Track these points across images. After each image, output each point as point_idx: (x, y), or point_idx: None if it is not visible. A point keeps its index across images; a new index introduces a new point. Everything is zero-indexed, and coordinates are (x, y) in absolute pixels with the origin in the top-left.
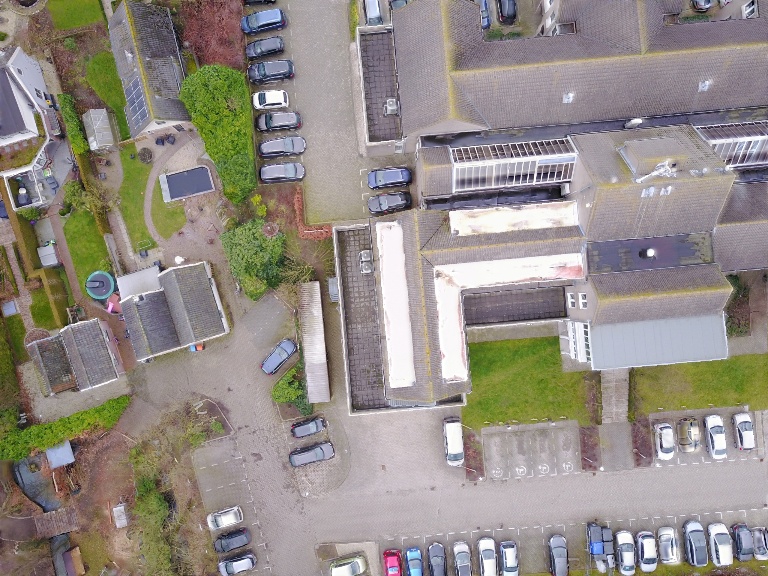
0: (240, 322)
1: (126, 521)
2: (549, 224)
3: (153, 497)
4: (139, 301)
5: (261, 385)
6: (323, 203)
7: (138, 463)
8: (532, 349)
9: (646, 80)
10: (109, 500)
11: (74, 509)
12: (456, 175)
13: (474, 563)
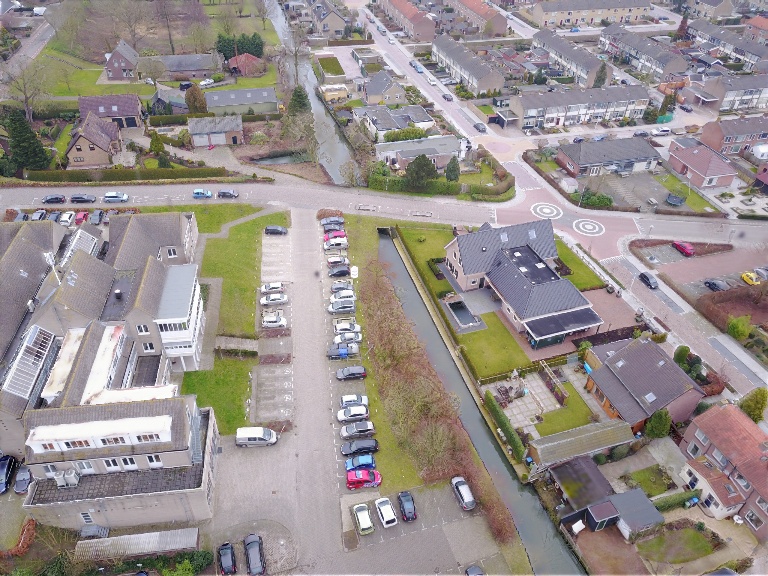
0: None
1: None
2: (78, 342)
3: None
4: None
5: None
6: (1, 536)
7: None
8: (190, 387)
9: (2, 294)
10: None
11: None
12: (13, 392)
13: None
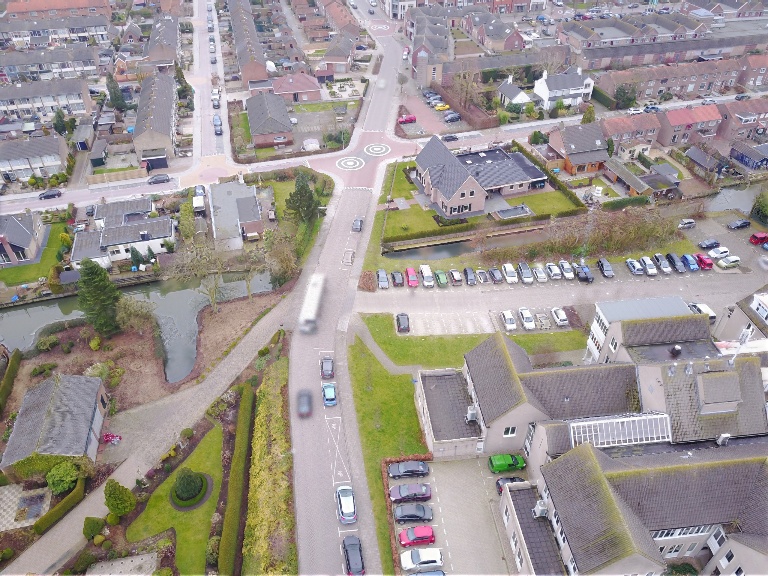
0: None
1: None
2: None
3: None
4: None
5: None
6: None
7: None
8: None
9: None
10: None
11: None
12: None
13: None
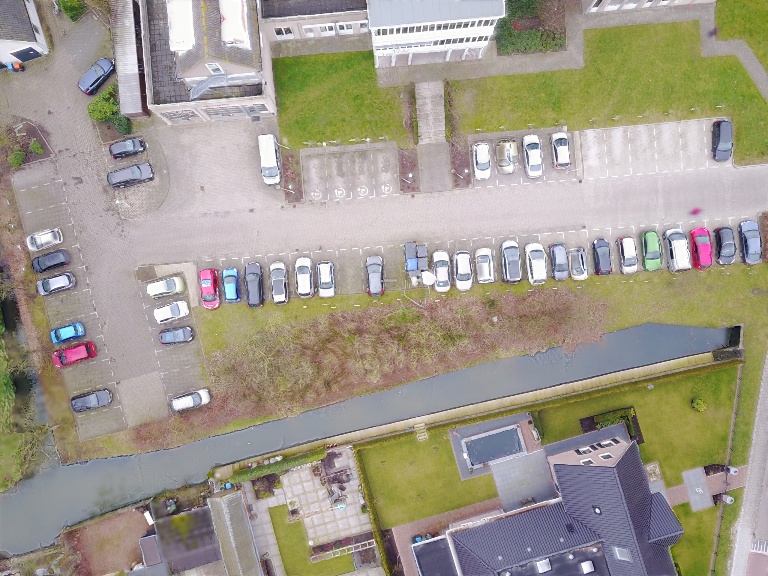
0: (60, 44)
1: None
2: None
3: None
4: None
5: (81, 107)
6: None
7: None
8: (346, 63)
9: None
10: None
11: None
12: None
13: (292, 283)
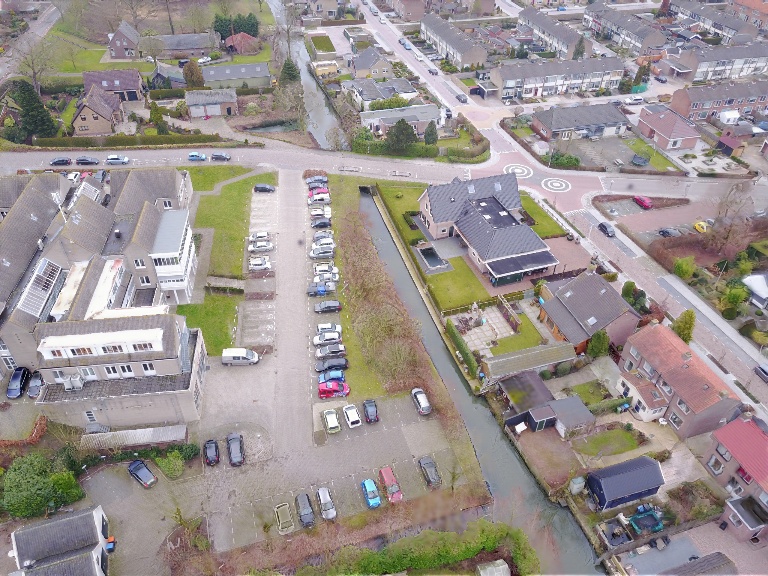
0: None
1: None
2: (82, 273)
3: None
4: (32, 567)
5: (166, 492)
6: (17, 430)
7: None
8: None
9: (15, 233)
10: None
11: None
12: (26, 310)
13: None
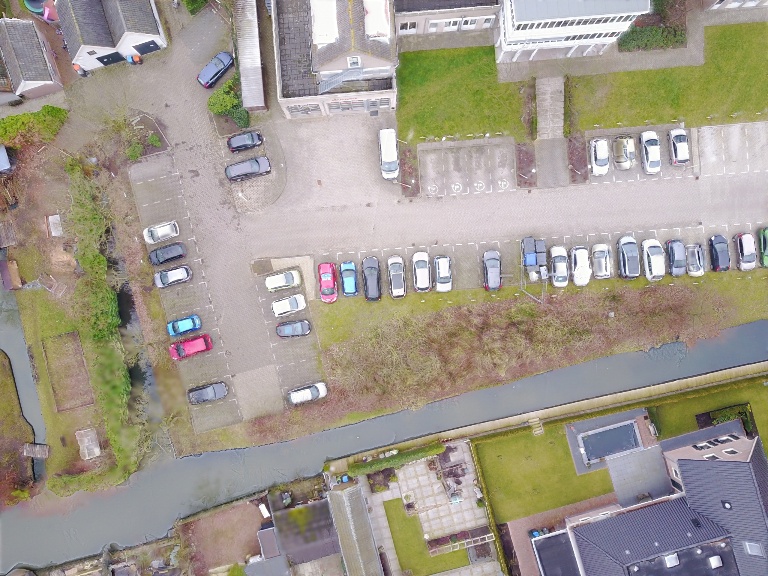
0: (178, 37)
1: (61, 229)
2: None
3: (88, 204)
4: None
5: (198, 101)
6: None
7: (74, 171)
8: (467, 58)
9: None
10: (46, 214)
11: (11, 224)
12: None
13: (408, 278)
